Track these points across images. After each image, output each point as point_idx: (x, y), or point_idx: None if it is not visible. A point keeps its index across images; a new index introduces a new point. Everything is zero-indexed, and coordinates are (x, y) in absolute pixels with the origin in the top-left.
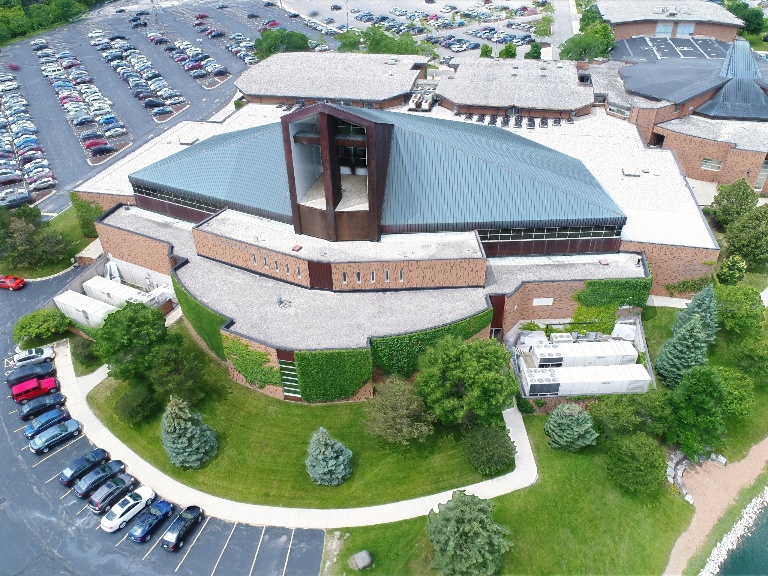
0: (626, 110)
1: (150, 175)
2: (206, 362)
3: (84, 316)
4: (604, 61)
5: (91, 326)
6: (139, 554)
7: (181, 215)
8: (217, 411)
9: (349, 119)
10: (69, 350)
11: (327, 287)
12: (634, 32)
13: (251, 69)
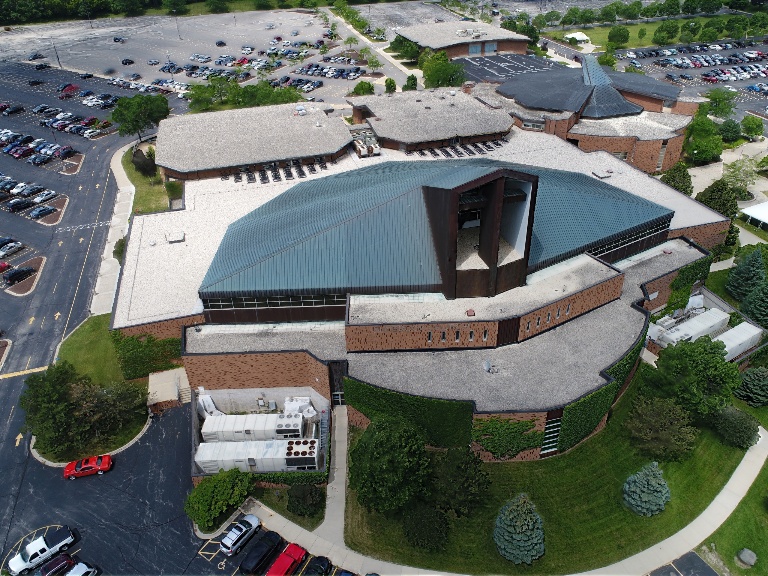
0: (542, 124)
1: (232, 284)
2: (429, 457)
3: (249, 465)
4: (473, 84)
5: (282, 471)
6: None
7: (277, 318)
8: (495, 497)
9: (521, 178)
10: (268, 508)
11: (512, 341)
12: (452, 55)
13: (159, 144)
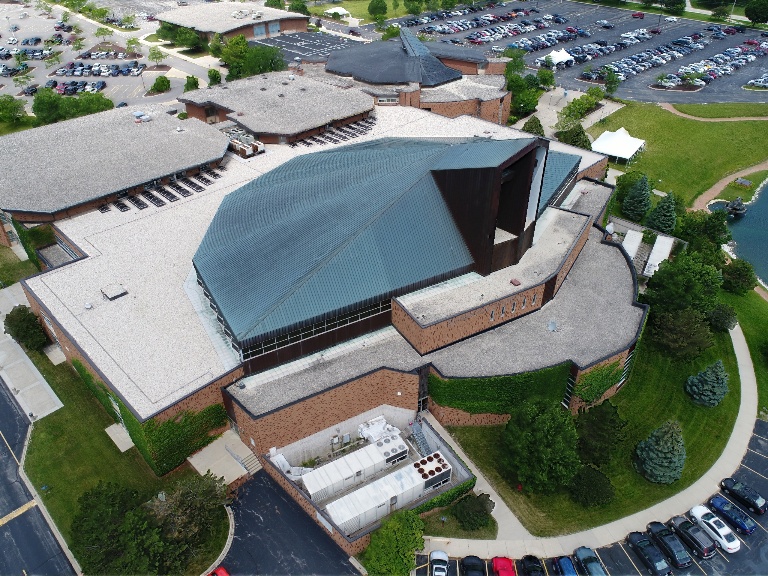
0: (396, 97)
1: (275, 321)
2: None
3: None
4: None
5: (435, 494)
6: (762, 534)
7: (322, 345)
8: None
9: (543, 145)
10: (439, 538)
11: (549, 298)
12: None
13: None
